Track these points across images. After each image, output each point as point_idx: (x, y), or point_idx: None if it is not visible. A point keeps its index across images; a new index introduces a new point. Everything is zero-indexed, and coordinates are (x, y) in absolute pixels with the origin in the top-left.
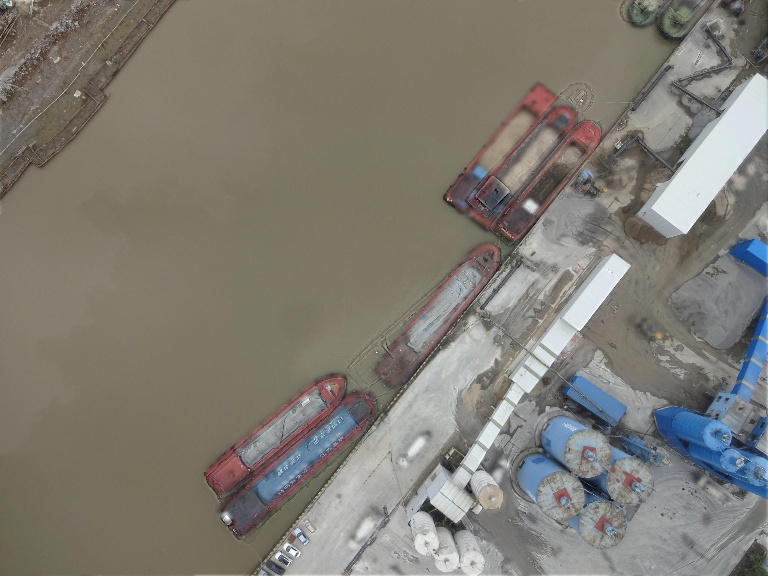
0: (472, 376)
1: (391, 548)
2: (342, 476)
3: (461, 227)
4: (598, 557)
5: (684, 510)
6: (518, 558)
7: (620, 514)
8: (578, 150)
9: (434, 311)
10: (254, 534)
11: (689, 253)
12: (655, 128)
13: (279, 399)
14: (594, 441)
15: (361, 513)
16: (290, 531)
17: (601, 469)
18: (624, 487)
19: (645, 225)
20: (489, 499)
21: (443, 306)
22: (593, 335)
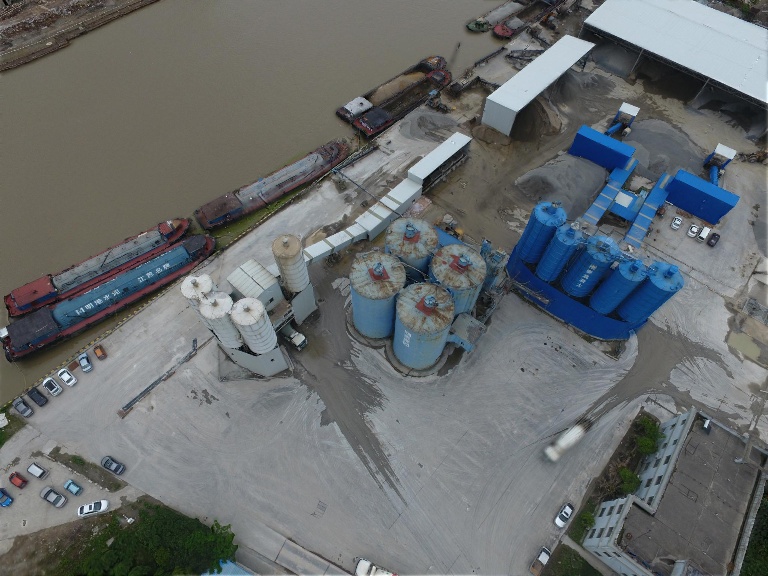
0: (319, 226)
1: (189, 386)
2: (157, 305)
3: (329, 127)
4: (445, 414)
5: (548, 366)
6: (344, 408)
7: (447, 297)
8: (433, 88)
9: (289, 170)
10: (33, 363)
11: (531, 152)
12: (495, 79)
13: (119, 236)
14: (419, 226)
15: (166, 344)
16: (75, 357)
17: (426, 252)
18: (451, 269)
19: (488, 127)
20: (283, 246)
21: (299, 168)
22: (443, 203)
